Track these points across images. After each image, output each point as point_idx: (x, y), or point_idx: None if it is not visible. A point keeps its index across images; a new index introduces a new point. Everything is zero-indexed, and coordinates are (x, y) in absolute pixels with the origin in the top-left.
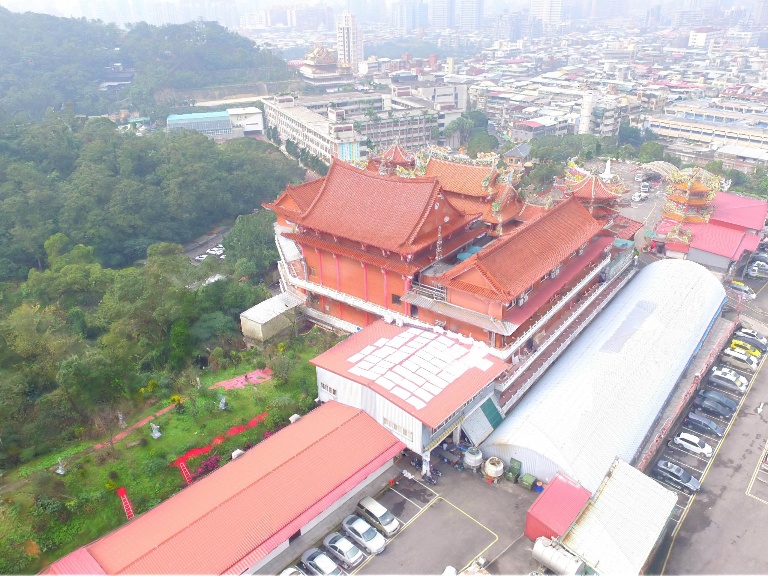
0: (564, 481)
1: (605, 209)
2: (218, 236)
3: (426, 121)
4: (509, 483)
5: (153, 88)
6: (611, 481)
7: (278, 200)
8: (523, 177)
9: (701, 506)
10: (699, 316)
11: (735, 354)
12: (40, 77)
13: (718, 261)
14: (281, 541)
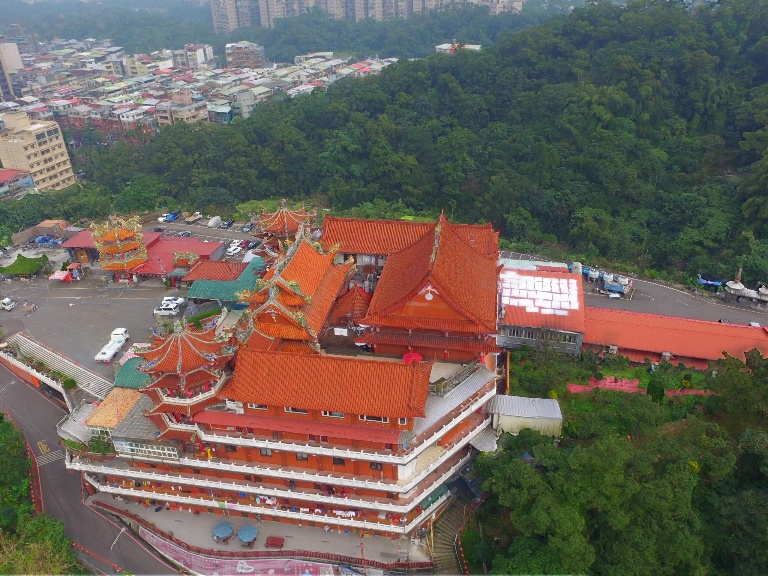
0: None
1: None
2: None
3: None
4: None
5: None
6: None
7: None
8: None
9: None
10: None
11: None
12: None
13: None
14: (680, 318)
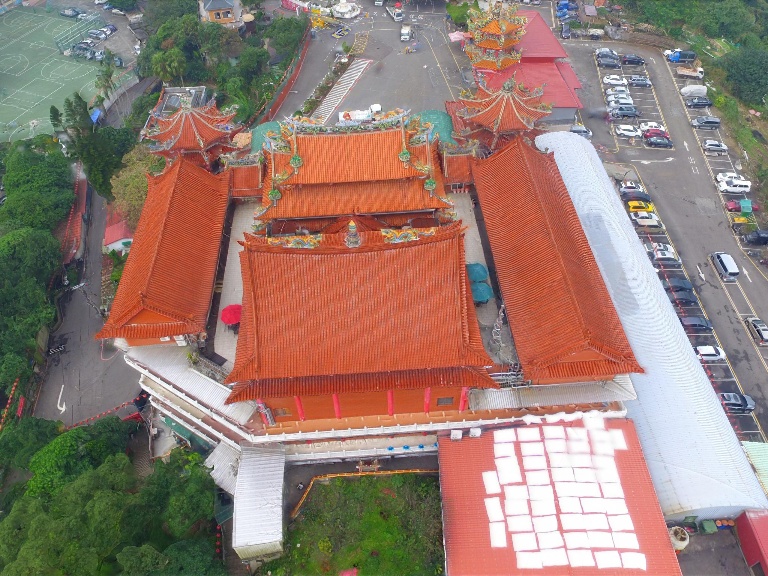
0: (757, 518)
1: (531, 131)
2: None
3: None
4: (690, 539)
5: None
6: (761, 475)
7: (125, 321)
8: (244, 35)
9: (765, 420)
10: (620, 203)
11: (647, 222)
12: None
13: (566, 114)
14: None
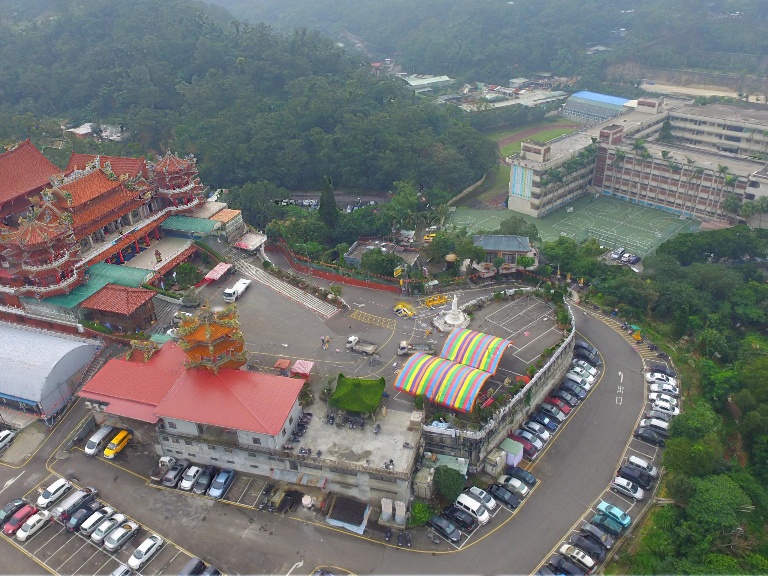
0: None
1: None
2: None
3: (727, 182)
4: None
5: (606, 60)
6: None
7: None
8: None
9: None
10: None
11: None
12: (534, 34)
13: None
14: None
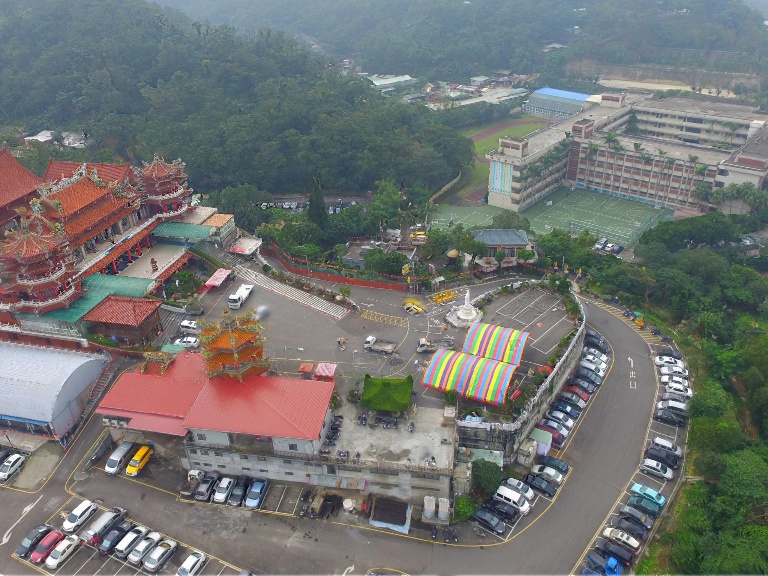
0: None
1: None
2: (300, 198)
3: (697, 171)
4: None
5: (564, 57)
6: None
7: None
8: None
9: None
10: None
11: None
12: (492, 32)
13: None
14: None
